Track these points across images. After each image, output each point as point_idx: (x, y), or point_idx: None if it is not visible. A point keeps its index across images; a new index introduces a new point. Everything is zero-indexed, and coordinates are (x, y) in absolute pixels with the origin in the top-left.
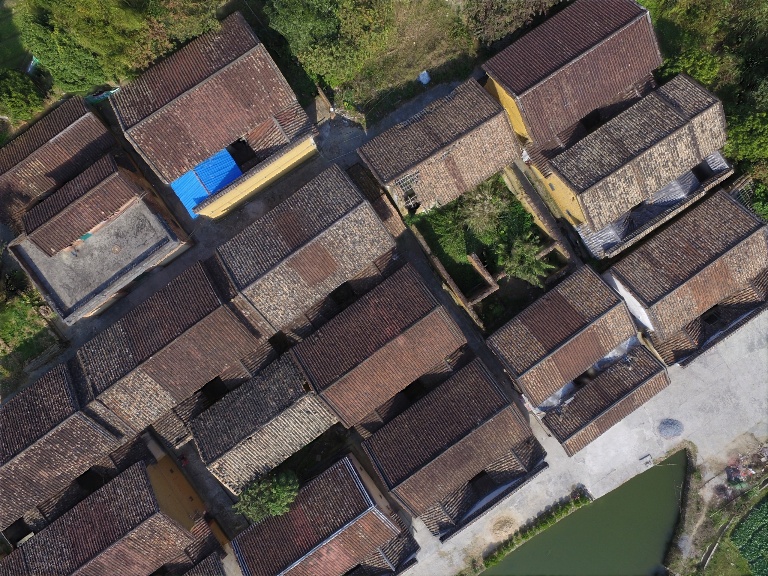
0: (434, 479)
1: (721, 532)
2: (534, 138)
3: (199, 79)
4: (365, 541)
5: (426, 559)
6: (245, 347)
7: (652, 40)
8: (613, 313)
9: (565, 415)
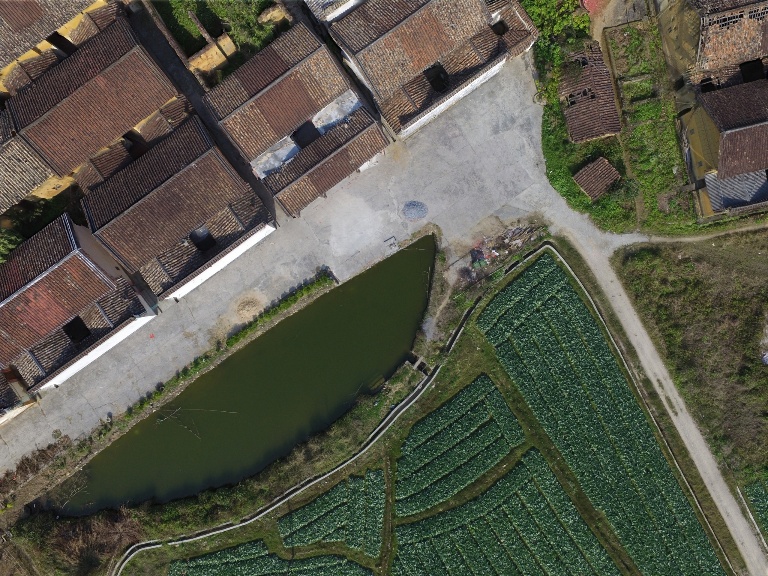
0: (143, 228)
1: (467, 317)
2: None
3: None
4: (76, 291)
5: (171, 339)
6: None
7: None
8: (316, 60)
9: (282, 173)
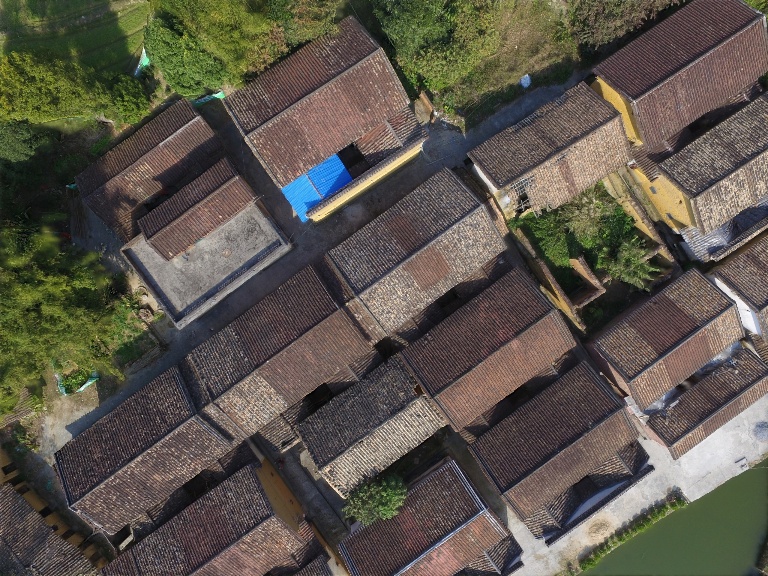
0: (544, 482)
1: None
2: (646, 142)
3: (319, 83)
4: (474, 544)
5: None
6: (357, 351)
7: (765, 44)
8: (724, 317)
9: (671, 418)
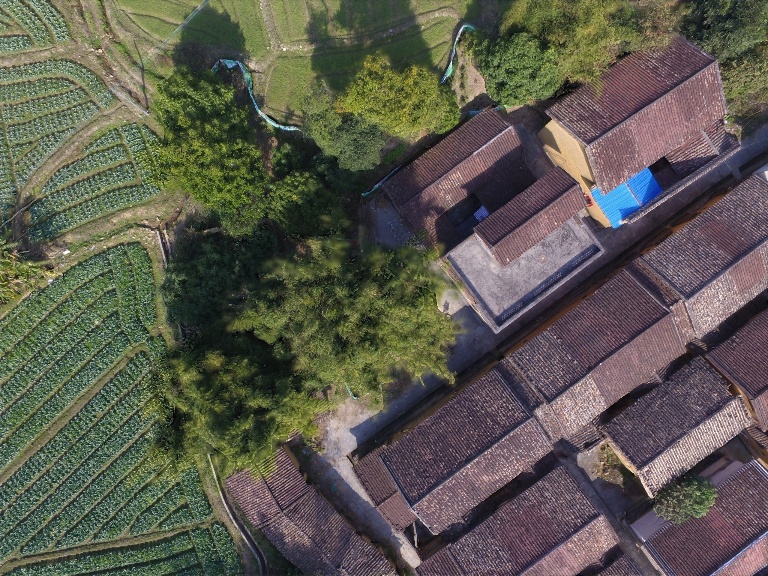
0: None
1: None
2: None
3: (655, 94)
4: None
5: None
6: (674, 353)
7: None
8: None
9: None
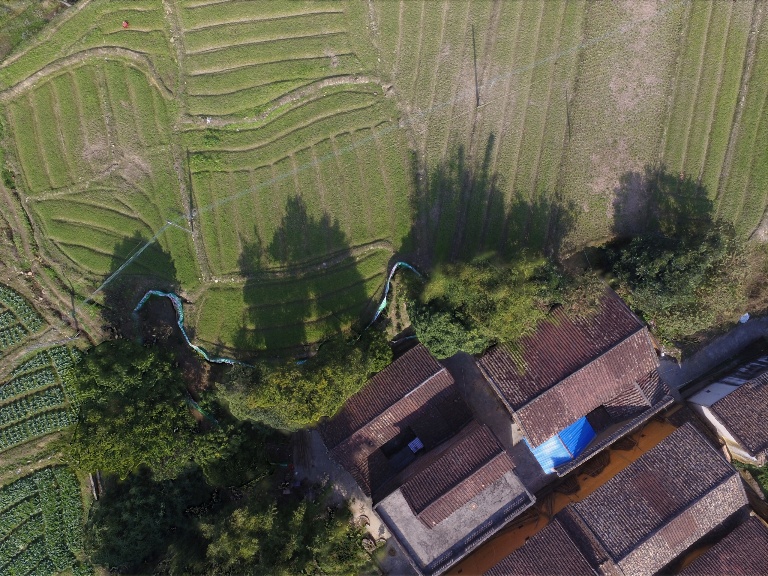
0: None
1: None
2: None
3: (583, 358)
4: None
5: None
6: None
7: None
8: None
9: None
